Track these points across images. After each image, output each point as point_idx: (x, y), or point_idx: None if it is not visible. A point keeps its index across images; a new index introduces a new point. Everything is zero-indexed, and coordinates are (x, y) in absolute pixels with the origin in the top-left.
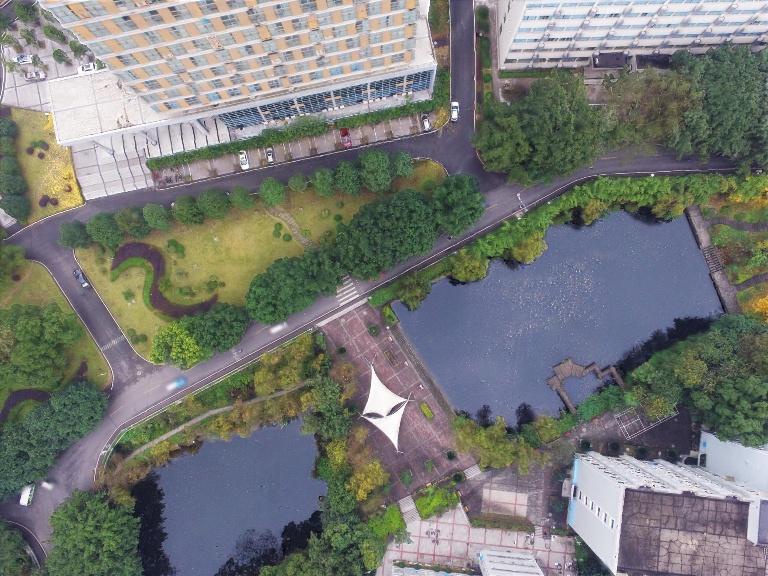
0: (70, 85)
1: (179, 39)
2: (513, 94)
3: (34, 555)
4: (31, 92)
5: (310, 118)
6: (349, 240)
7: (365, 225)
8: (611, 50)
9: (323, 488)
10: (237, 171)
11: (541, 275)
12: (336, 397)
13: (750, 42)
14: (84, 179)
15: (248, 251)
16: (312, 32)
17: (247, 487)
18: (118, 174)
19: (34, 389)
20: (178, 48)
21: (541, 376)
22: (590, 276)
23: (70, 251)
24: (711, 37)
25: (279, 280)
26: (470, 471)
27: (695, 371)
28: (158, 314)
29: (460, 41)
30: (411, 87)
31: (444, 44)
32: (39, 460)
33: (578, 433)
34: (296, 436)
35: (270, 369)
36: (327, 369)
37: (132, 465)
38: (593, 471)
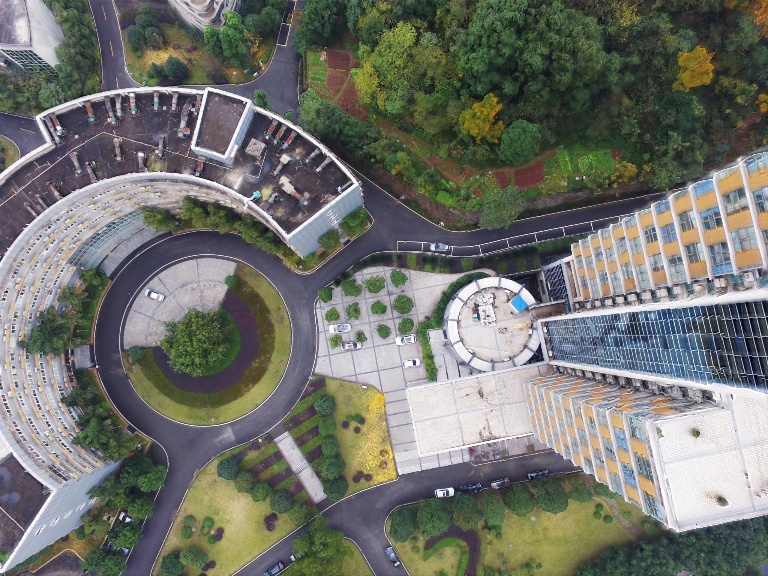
0: (430, 393)
1: None
2: None
3: None
4: (346, 361)
5: None
6: (695, 543)
7: (719, 534)
8: None
9: None
10: None
11: None
12: None
13: None
14: (401, 455)
15: (566, 532)
16: None
17: None
18: None
19: None
20: None
21: None
22: None
23: (381, 527)
24: None
25: None
26: None
27: None
28: None
29: None
30: None
31: None
32: None
33: None
34: None
35: None
36: None
37: None
38: None
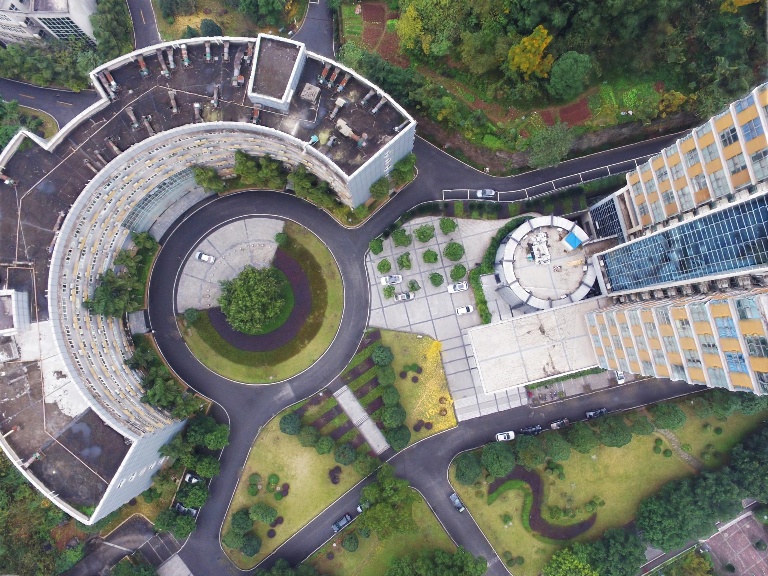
0: (492, 332)
1: None
2: None
3: None
4: (399, 312)
5: None
6: (758, 468)
7: None
8: None
9: None
10: (612, 386)
11: None
12: None
13: None
14: (460, 402)
15: (627, 468)
16: None
17: None
18: (493, 395)
19: None
20: None
21: None
22: None
23: (444, 474)
24: None
25: (686, 510)
26: None
27: None
28: (537, 536)
29: None
30: None
31: None
32: None
33: None
34: None
35: None
36: None
37: None
38: None
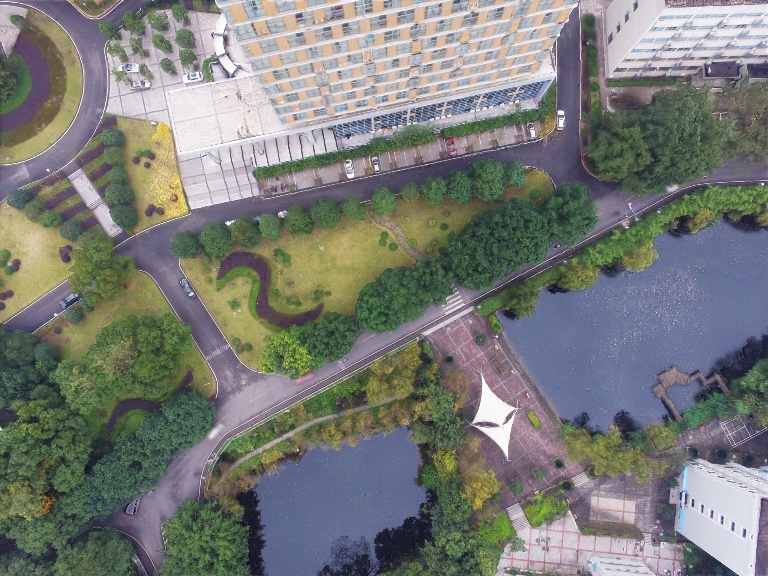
0: (189, 96)
1: (337, 54)
2: (621, 103)
3: (141, 564)
4: (136, 101)
5: (419, 127)
6: (463, 250)
7: (481, 235)
8: (724, 59)
9: (421, 495)
10: (342, 180)
11: (644, 283)
12: (450, 406)
13: None
14: (190, 188)
15: (354, 260)
16: (460, 45)
17: (351, 495)
18: (224, 183)
19: (141, 398)
20: (331, 62)
21: (646, 384)
22: (693, 284)
23: (175, 260)
24: None
25: (392, 290)
26: (578, 479)
27: None
28: (264, 323)
29: (566, 49)
30: (520, 96)
31: None
32: (152, 470)
33: (685, 441)
34: (399, 444)
35: (382, 378)
36: (438, 378)
37: (237, 474)
38: (712, 480)
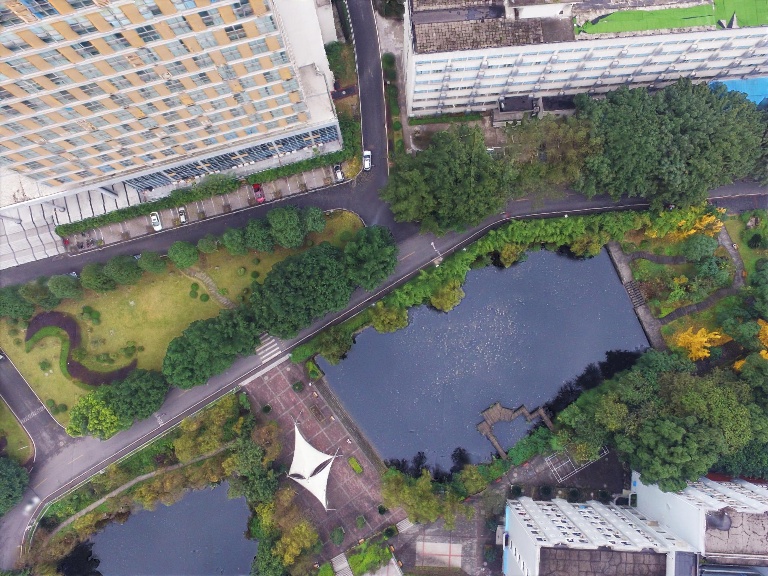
0: None
1: (46, 126)
2: (424, 141)
3: None
4: None
5: (219, 177)
6: (263, 300)
7: (276, 285)
8: (516, 94)
9: None
10: (150, 233)
11: (465, 320)
12: (258, 460)
13: (652, 80)
14: None
15: (165, 313)
16: (189, 107)
17: (180, 553)
18: (27, 243)
19: None
20: (48, 133)
21: (470, 422)
22: (514, 318)
23: None
24: (612, 78)
25: (194, 344)
26: (402, 524)
27: (614, 415)
28: (77, 383)
29: (369, 89)
30: (320, 139)
31: (353, 93)
32: None
33: (509, 479)
34: None
35: (191, 435)
36: (249, 431)
37: None
38: (518, 523)
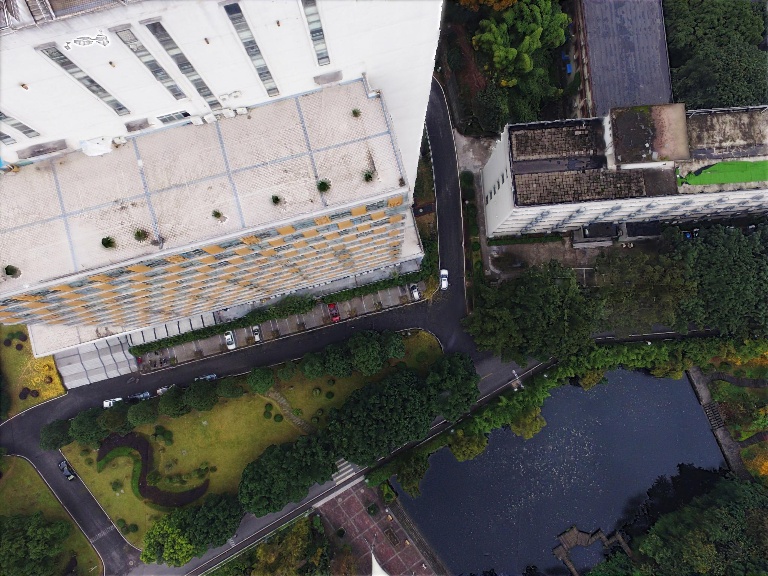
0: None
1: (155, 303)
2: (503, 262)
3: None
4: None
5: (296, 299)
6: (342, 429)
7: (358, 417)
8: (601, 221)
9: None
10: (223, 351)
11: (541, 440)
12: None
13: (741, 210)
14: (65, 369)
15: (239, 433)
16: None
17: None
18: (100, 362)
19: None
20: None
21: (546, 546)
22: (591, 439)
23: None
24: (702, 210)
25: (272, 473)
26: None
27: (704, 559)
28: (148, 503)
29: (446, 207)
30: None
31: (430, 211)
32: None
33: None
34: None
35: (267, 564)
36: (326, 559)
37: None
38: None
